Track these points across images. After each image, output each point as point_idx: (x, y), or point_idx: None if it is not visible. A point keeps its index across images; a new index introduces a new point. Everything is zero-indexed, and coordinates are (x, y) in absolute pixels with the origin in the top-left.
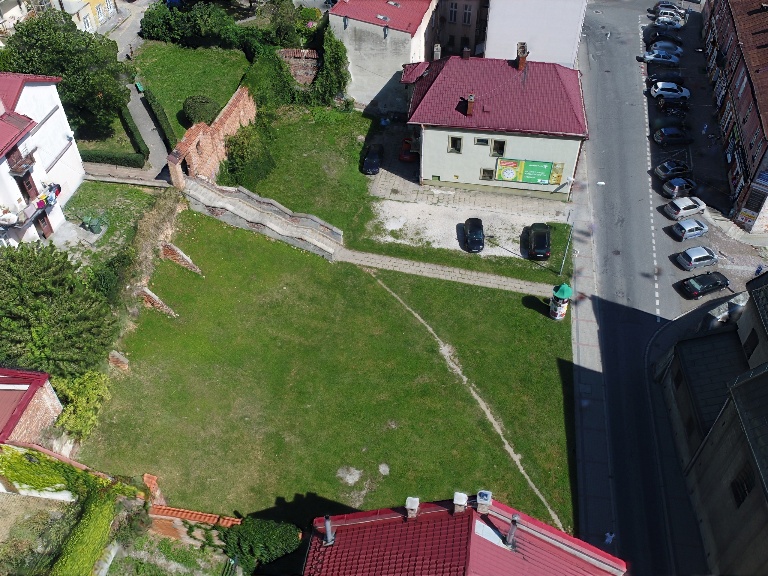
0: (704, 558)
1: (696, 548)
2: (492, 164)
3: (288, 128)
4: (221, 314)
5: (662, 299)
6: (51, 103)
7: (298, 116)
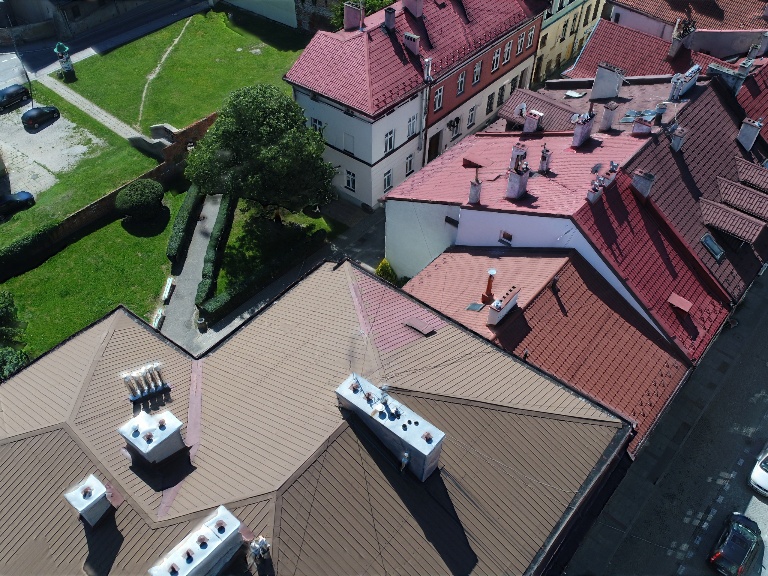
0: (151, 2)
1: (150, 4)
2: None
3: None
4: None
5: (0, 61)
6: None
7: None
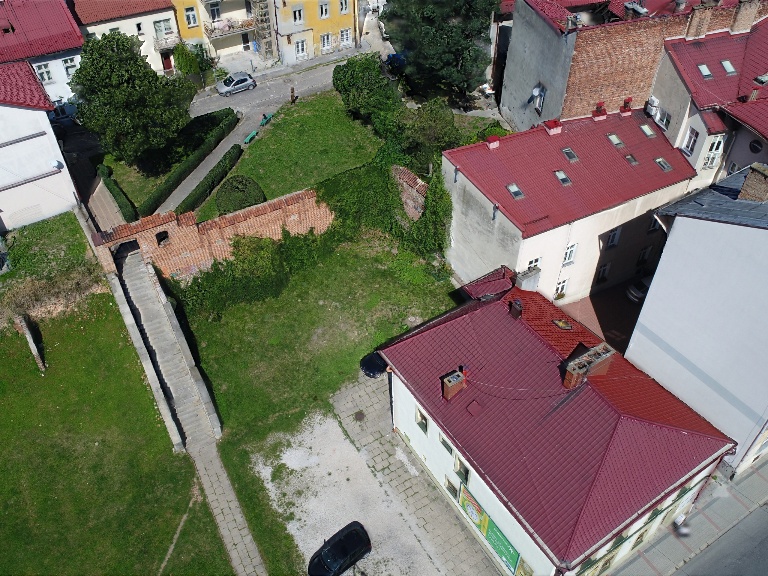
0: None
1: None
2: (456, 482)
3: (348, 259)
4: (8, 426)
5: None
6: (35, 127)
7: (379, 250)
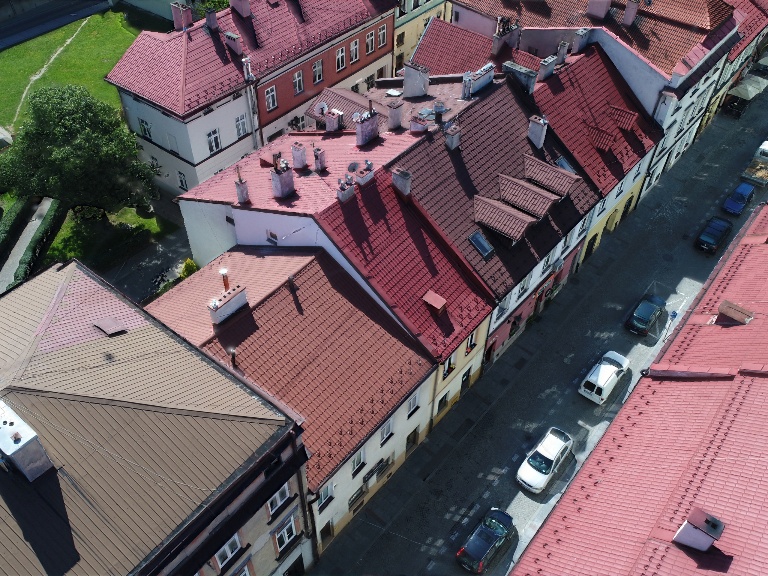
0: (52, 2)
1: None
2: None
3: None
4: None
5: None
6: None
7: None
